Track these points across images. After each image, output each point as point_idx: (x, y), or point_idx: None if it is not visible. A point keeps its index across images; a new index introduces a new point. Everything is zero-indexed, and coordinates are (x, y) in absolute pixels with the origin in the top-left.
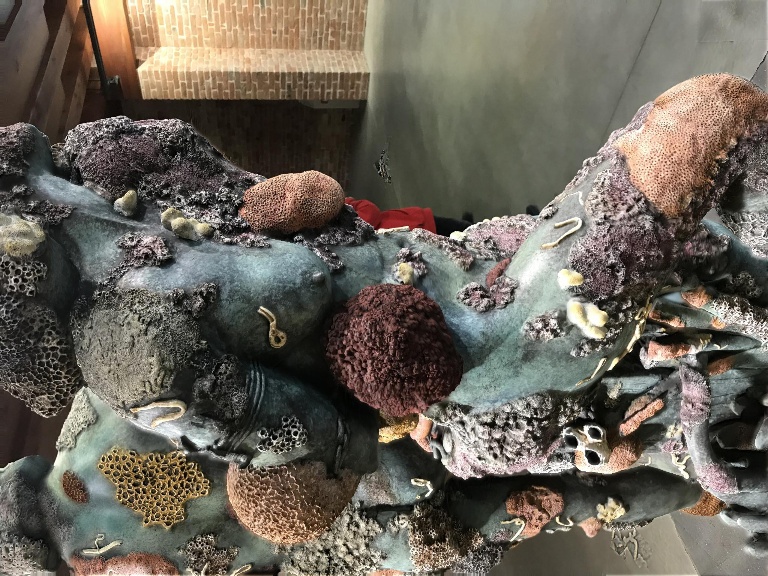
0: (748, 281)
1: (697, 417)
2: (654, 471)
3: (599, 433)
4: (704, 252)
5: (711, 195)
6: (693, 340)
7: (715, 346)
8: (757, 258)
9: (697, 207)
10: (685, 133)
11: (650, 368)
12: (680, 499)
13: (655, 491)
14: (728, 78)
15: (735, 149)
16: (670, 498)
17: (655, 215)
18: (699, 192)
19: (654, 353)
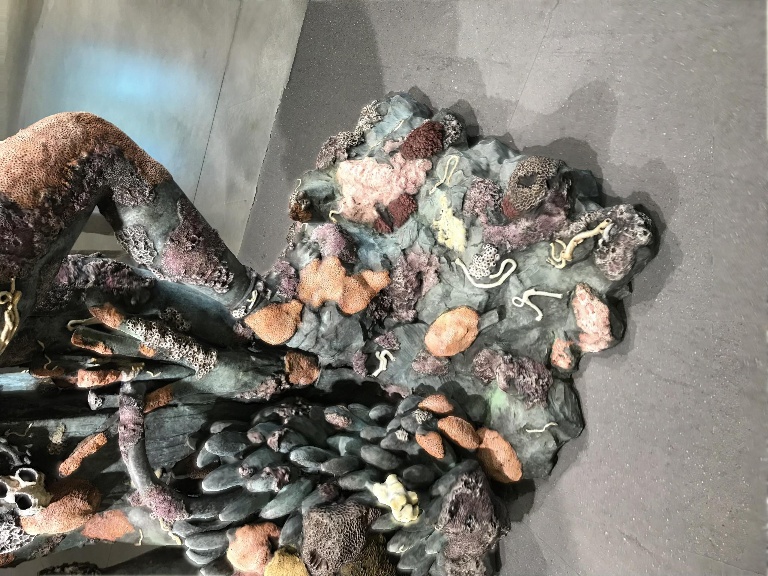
0: (175, 316)
1: (129, 438)
2: (156, 551)
3: (33, 475)
4: (124, 285)
5: (72, 198)
6: (125, 368)
7: (148, 373)
8: (182, 297)
9: (55, 204)
10: (36, 142)
11: (97, 409)
12: (184, 575)
13: (155, 570)
14: (82, 112)
15: (86, 160)
16: (172, 575)
17: (5, 203)
18: (53, 190)
19: (81, 379)
